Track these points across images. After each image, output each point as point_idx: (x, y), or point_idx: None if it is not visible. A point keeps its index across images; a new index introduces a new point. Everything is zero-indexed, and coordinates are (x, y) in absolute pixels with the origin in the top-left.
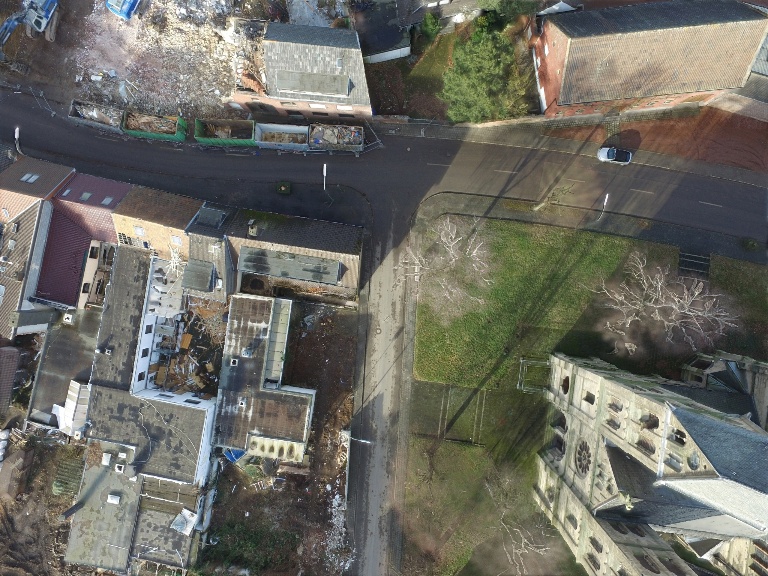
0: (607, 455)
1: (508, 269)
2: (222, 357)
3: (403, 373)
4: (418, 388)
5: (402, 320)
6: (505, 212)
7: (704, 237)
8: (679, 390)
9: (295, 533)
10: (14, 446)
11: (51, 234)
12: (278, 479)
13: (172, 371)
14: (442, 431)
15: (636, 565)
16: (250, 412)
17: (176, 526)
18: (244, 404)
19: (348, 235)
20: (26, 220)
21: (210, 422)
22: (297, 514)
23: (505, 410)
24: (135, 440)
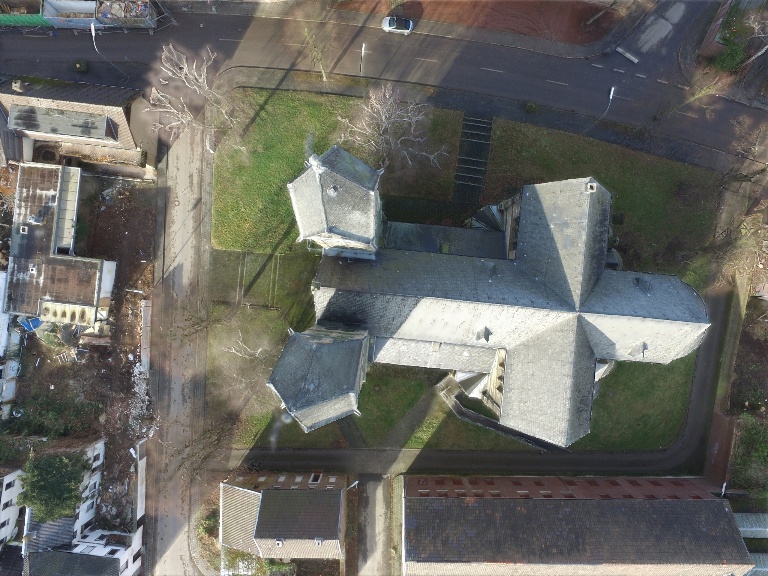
0: None
1: (298, 137)
2: None
3: (202, 243)
4: (216, 257)
5: (199, 191)
6: (296, 84)
7: (487, 102)
8: (435, 228)
9: (99, 403)
10: None
11: None
12: (80, 350)
13: None
14: (240, 297)
15: None
16: (41, 278)
17: None
18: (35, 271)
19: (121, 94)
20: None
21: (1, 289)
22: (101, 385)
23: (298, 273)
24: None
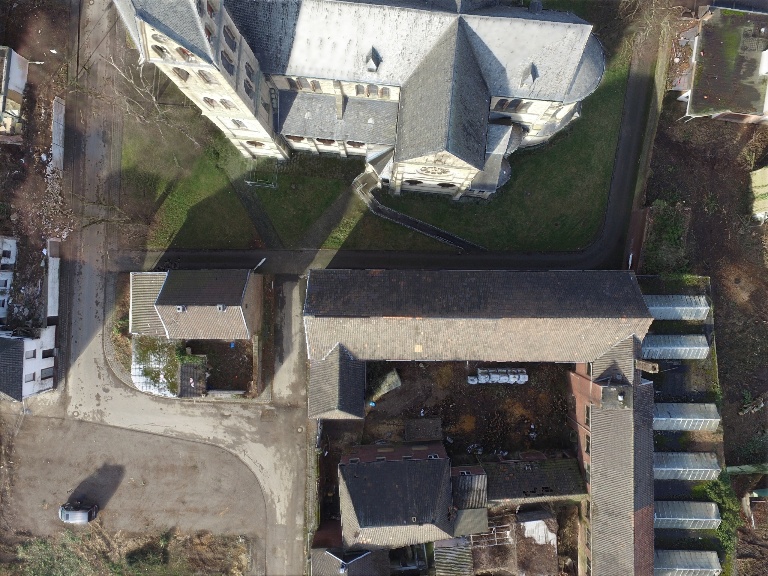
0: None
1: None
2: None
3: (117, 43)
4: (132, 56)
5: None
6: None
7: None
8: None
9: (11, 203)
10: None
11: None
12: None
13: None
14: None
15: None
16: None
17: None
18: None
19: None
20: None
21: None
22: (14, 186)
23: None
24: None
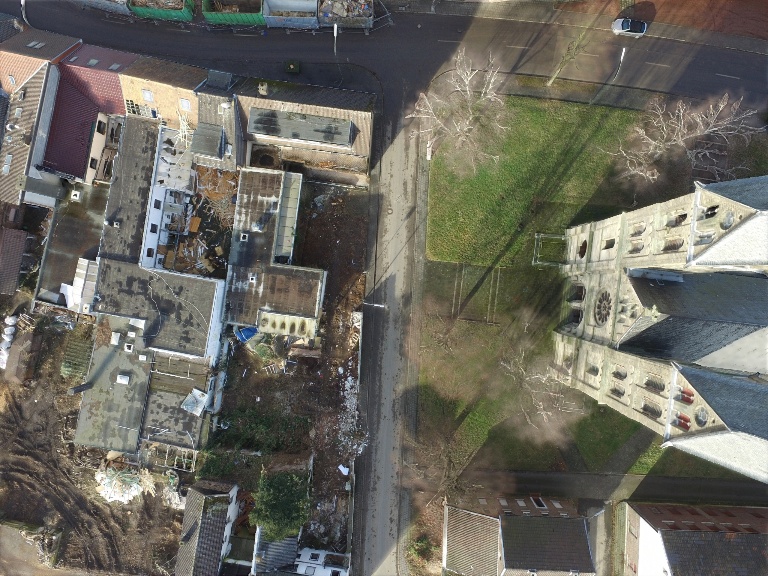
0: (630, 283)
1: (521, 145)
2: (232, 234)
3: (415, 253)
4: (431, 268)
5: (414, 200)
6: (518, 88)
7: None
8: None
9: (307, 417)
10: (22, 333)
11: (58, 103)
12: (289, 362)
13: (181, 254)
14: (456, 311)
15: (665, 365)
16: (261, 288)
17: (186, 406)
18: (255, 280)
19: (359, 98)
20: (33, 85)
21: (220, 298)
22: (309, 398)
23: (520, 287)
24: (144, 314)
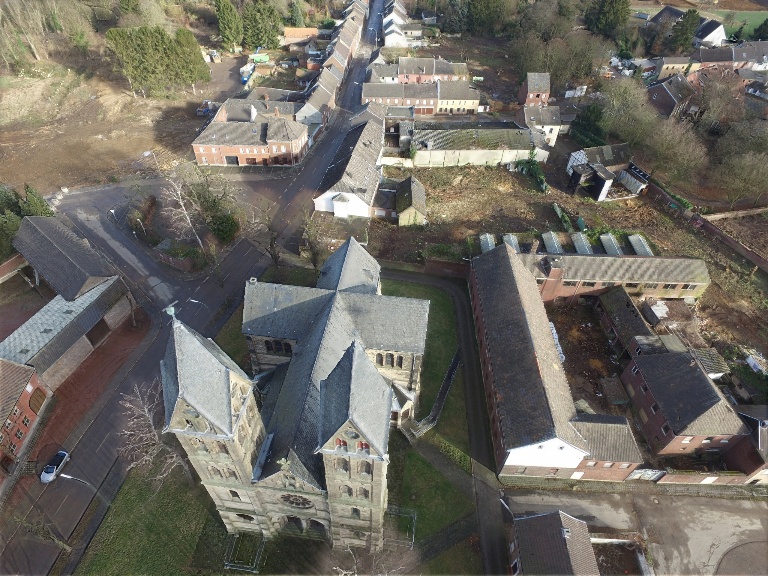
0: None
1: None
2: None
3: None
4: None
5: None
6: None
7: None
8: (261, 415)
9: None
10: None
11: None
12: None
13: None
14: None
15: None
16: None
17: None
18: None
19: None
20: None
21: None
22: None
23: None
24: None
